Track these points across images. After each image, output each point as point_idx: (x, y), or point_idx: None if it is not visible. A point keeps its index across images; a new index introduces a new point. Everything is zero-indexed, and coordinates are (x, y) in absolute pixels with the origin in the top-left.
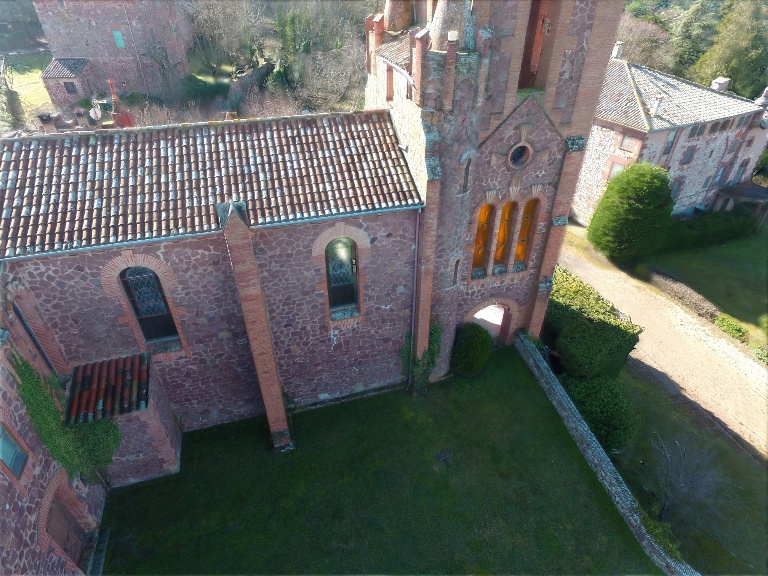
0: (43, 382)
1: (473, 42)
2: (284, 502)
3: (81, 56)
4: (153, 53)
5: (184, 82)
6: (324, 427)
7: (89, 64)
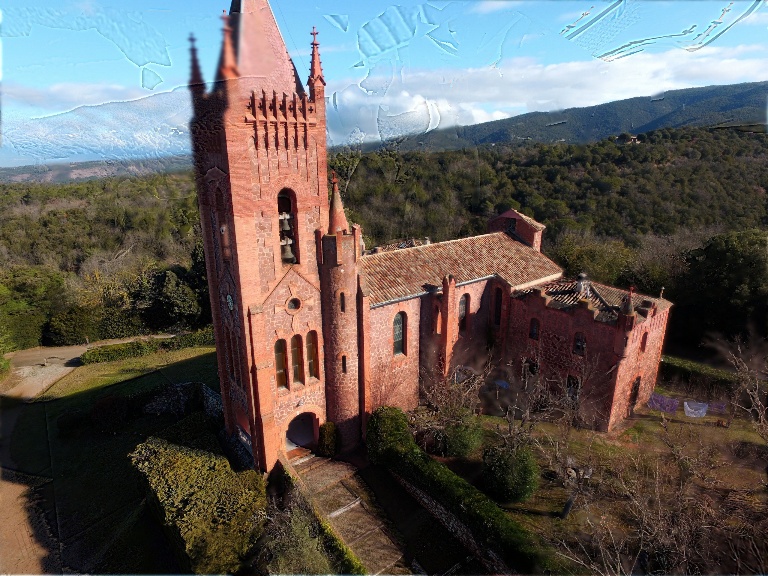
0: None
1: None
2: None
3: None
4: None
5: None
6: None
7: None
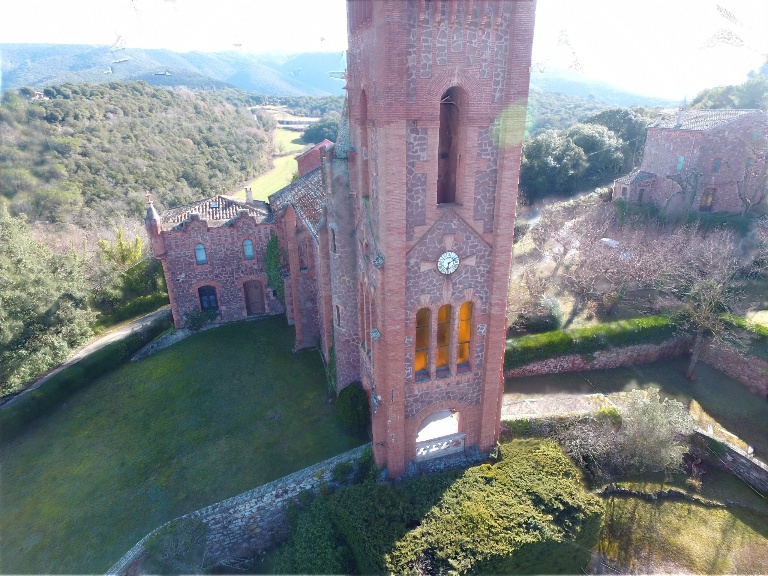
0: (280, 248)
1: (343, 154)
2: (264, 356)
3: (654, 172)
4: (687, 177)
5: (686, 206)
6: (306, 362)
7: (654, 178)
